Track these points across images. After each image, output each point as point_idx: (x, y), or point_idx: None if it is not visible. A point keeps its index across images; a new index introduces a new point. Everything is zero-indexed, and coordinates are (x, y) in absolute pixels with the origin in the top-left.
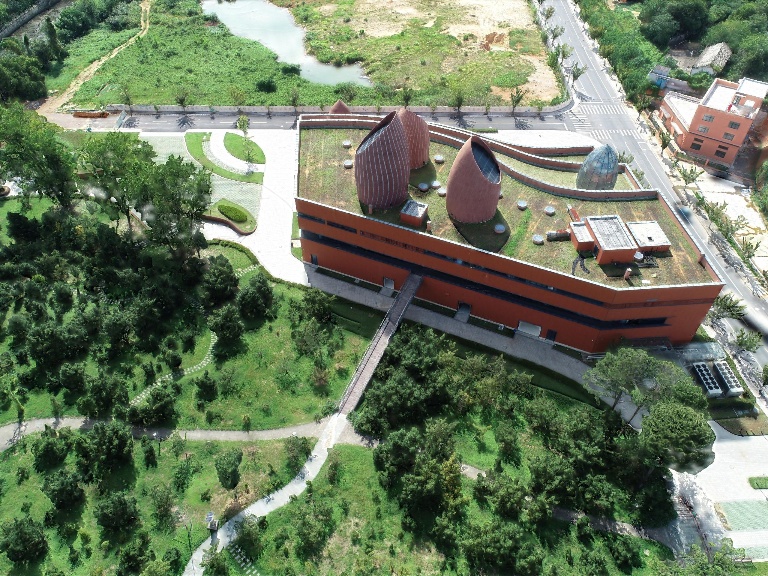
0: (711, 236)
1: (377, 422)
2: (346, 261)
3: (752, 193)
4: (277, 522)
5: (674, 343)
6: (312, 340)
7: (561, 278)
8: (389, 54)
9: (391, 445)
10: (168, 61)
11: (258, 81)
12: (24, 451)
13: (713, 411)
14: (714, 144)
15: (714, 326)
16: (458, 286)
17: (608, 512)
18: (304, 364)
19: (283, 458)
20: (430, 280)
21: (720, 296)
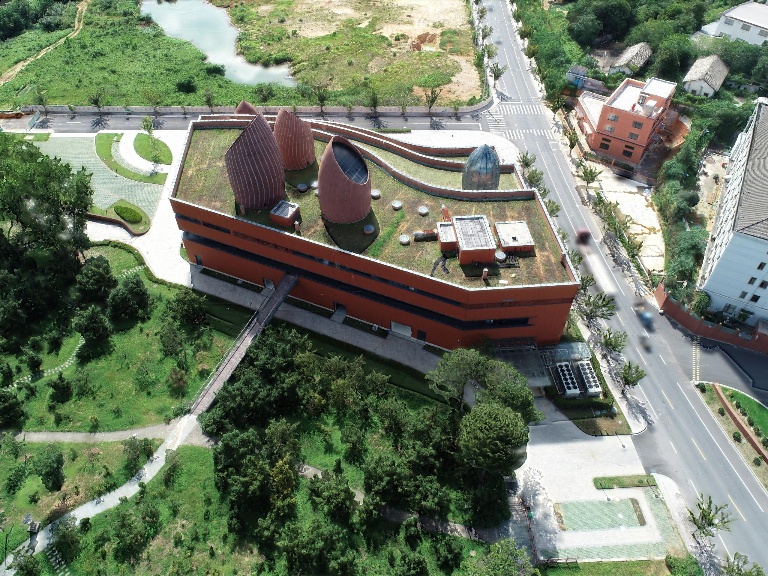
0: (604, 236)
1: (223, 423)
2: (227, 262)
3: (653, 193)
4: (101, 524)
5: (543, 343)
6: (170, 341)
7: (418, 278)
8: (317, 54)
9: (221, 446)
10: (93, 62)
11: (178, 82)
12: None
13: (571, 411)
14: (621, 144)
15: (590, 326)
16: (330, 286)
17: (442, 513)
18: (167, 365)
19: (122, 460)
20: (304, 281)
21: (602, 296)
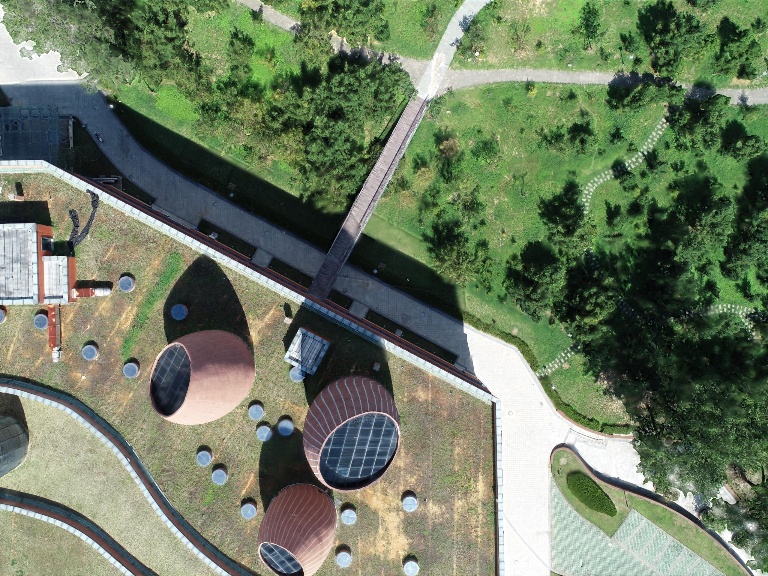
0: None
1: None
2: None
3: None
4: None
5: None
6: (461, 175)
7: None
8: None
9: (371, 4)
10: None
11: None
12: (767, 60)
13: None
14: None
15: None
16: (260, 267)
17: None
18: None
19: None
20: None
21: None
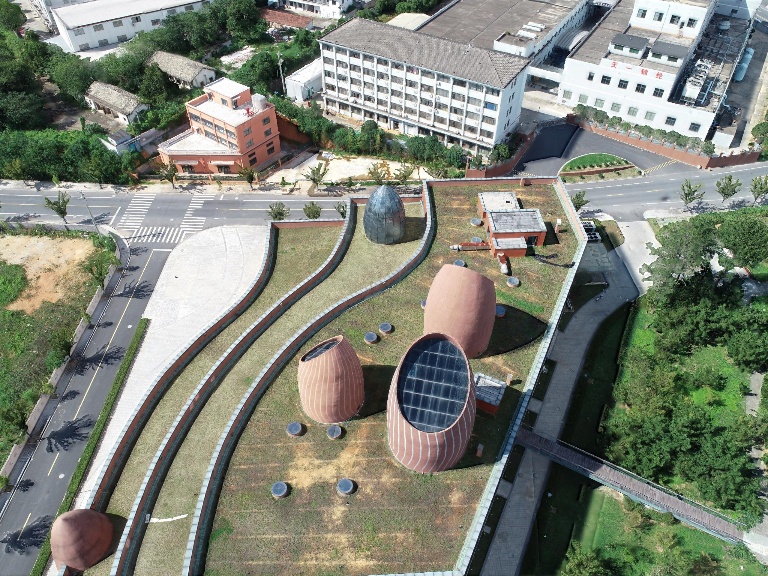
0: None
1: None
2: None
3: (331, 152)
4: None
5: None
6: None
7: None
8: None
9: None
10: None
11: None
12: None
13: None
14: (263, 147)
15: None
16: None
17: None
18: None
19: None
20: None
21: None
